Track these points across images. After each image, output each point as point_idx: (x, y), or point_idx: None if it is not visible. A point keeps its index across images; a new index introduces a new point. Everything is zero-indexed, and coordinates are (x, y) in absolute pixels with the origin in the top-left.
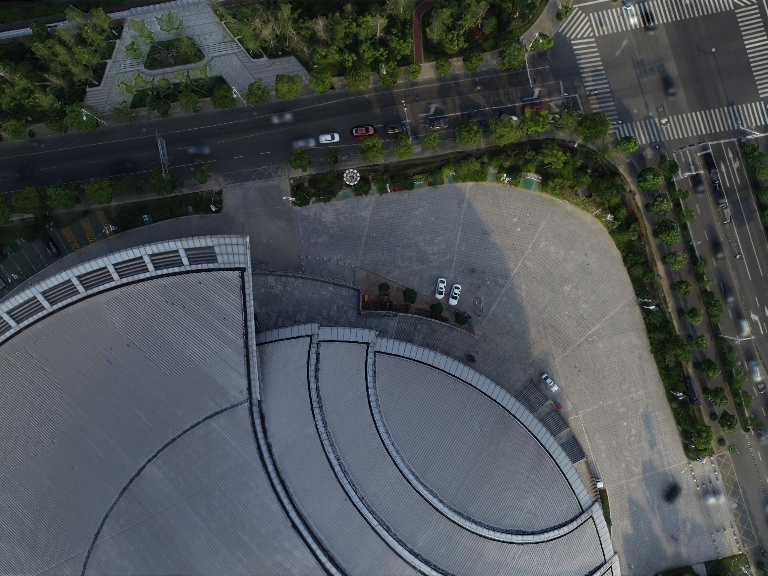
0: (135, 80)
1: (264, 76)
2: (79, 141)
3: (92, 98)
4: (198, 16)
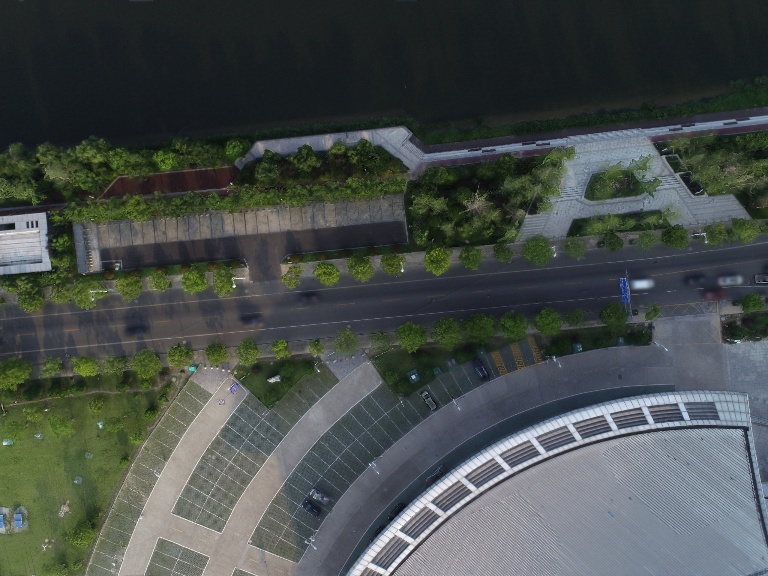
0: (611, 222)
1: (702, 213)
2: (513, 266)
3: (530, 224)
4: (638, 148)
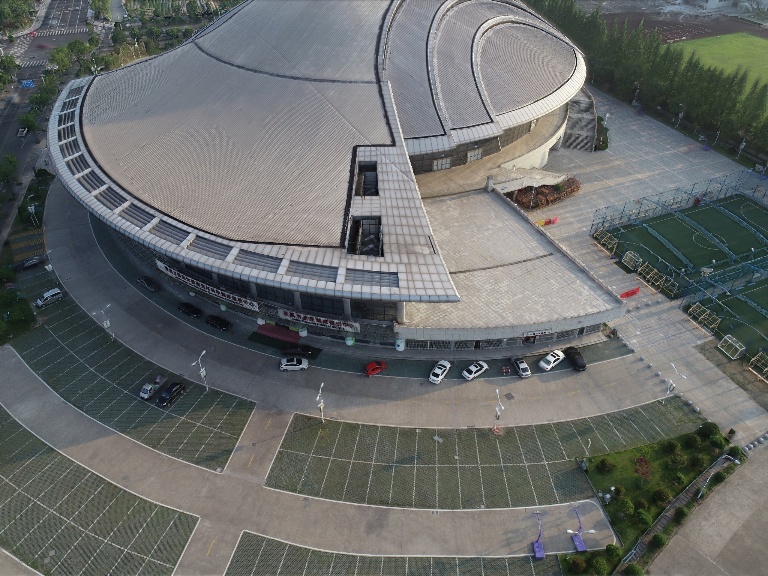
0: None
1: None
2: None
3: None
4: None
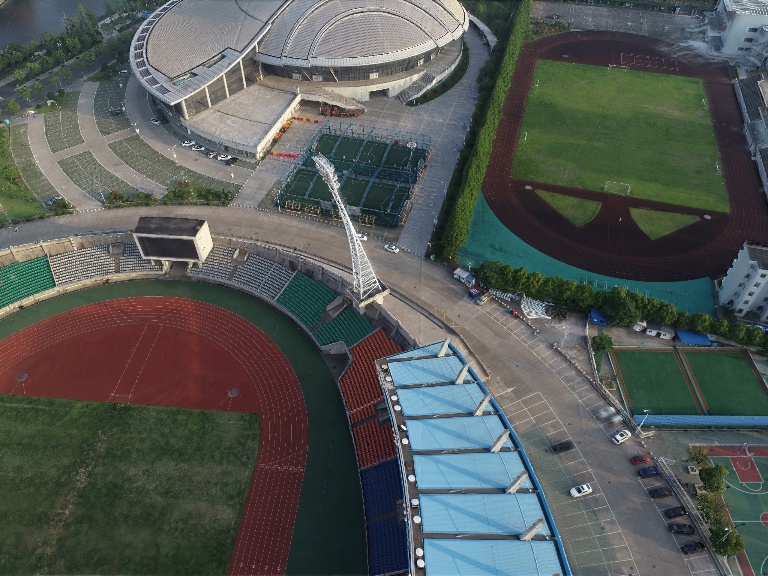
0: (119, 6)
1: None
2: None
3: None
4: None
